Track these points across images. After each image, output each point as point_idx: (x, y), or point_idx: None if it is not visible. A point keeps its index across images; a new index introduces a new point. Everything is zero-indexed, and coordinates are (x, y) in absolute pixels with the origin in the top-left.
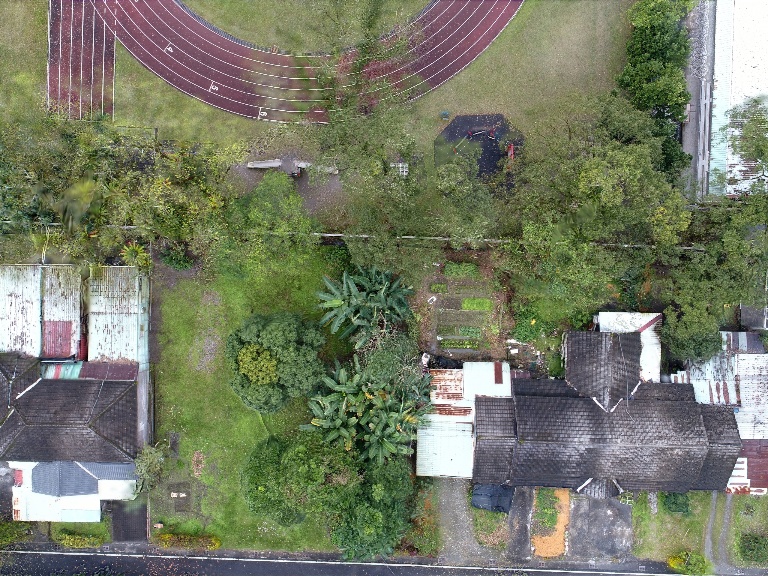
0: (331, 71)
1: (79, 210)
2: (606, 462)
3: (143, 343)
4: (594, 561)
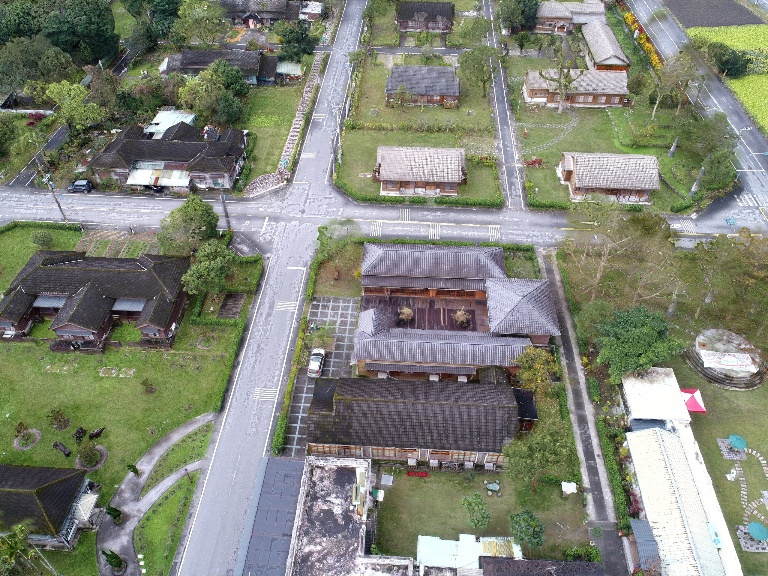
0: None
1: None
2: (252, 4)
3: None
4: None
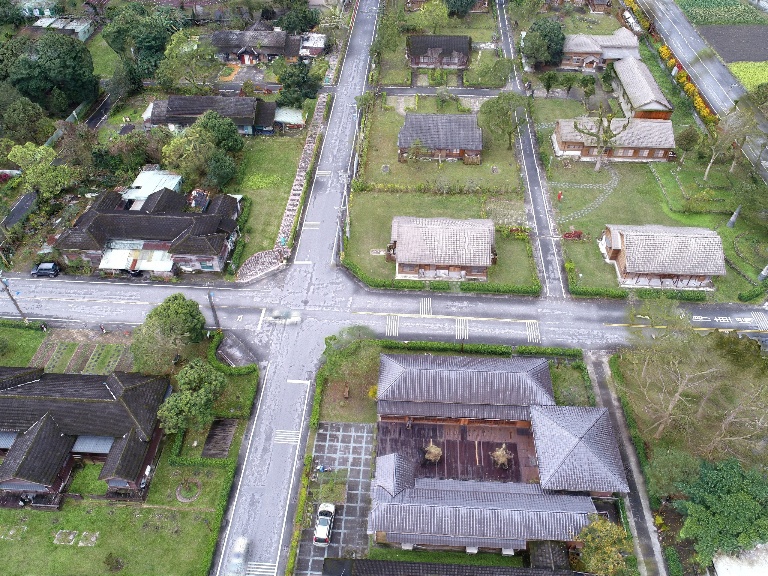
0: (185, 1)
1: (80, 5)
2: (247, 38)
3: (83, 36)
4: None
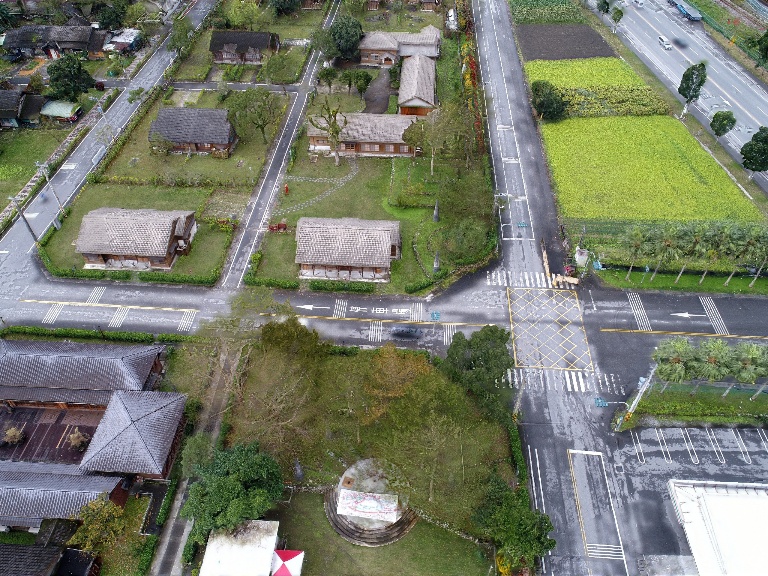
0: None
1: None
2: (52, 33)
3: None
4: (43, 76)
